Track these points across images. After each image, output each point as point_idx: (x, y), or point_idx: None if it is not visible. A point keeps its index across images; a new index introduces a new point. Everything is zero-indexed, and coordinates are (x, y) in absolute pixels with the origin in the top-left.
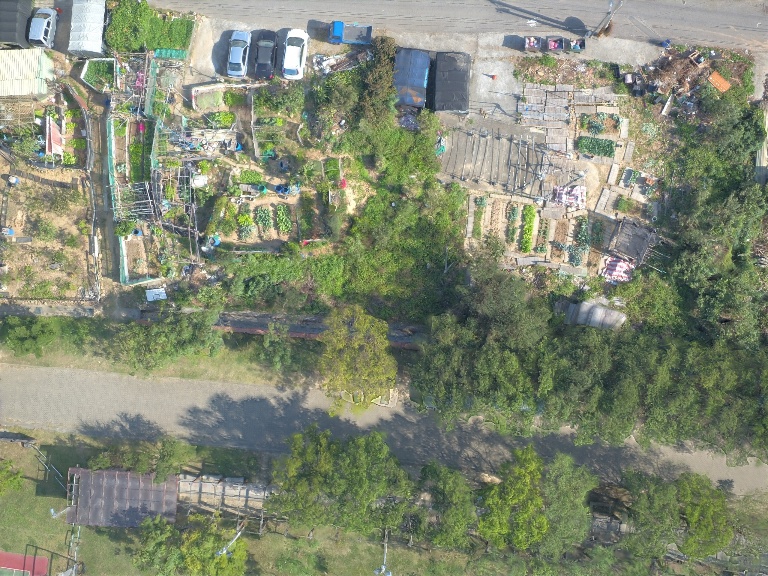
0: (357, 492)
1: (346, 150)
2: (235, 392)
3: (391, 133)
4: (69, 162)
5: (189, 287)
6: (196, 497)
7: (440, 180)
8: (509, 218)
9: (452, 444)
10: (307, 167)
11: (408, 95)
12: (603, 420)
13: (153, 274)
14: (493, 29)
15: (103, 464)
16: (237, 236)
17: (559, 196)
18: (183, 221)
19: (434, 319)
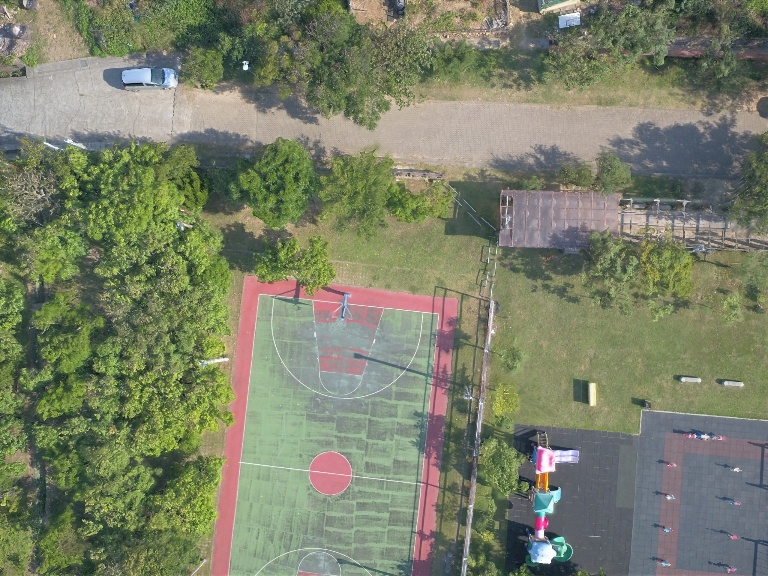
0: None
1: None
2: (657, 118)
3: None
4: None
5: (608, 9)
6: None
7: None
8: None
9: None
10: None
11: None
12: None
13: None
14: None
15: None
16: None
17: None
18: None
19: None
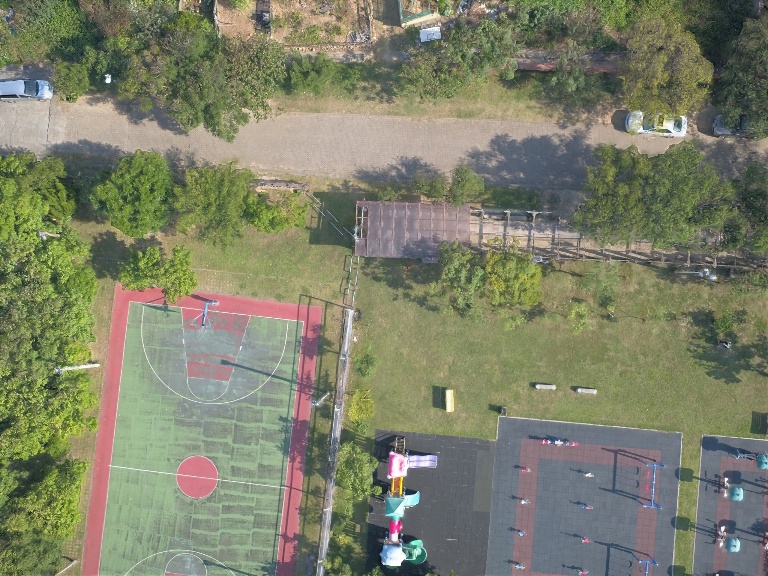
0: (683, 190)
1: None
2: (515, 130)
3: None
4: None
5: (467, 23)
6: (476, 238)
7: None
8: None
9: (742, 174)
10: None
11: None
12: None
13: None
14: None
15: (391, 197)
16: None
17: None
18: None
19: (746, 23)
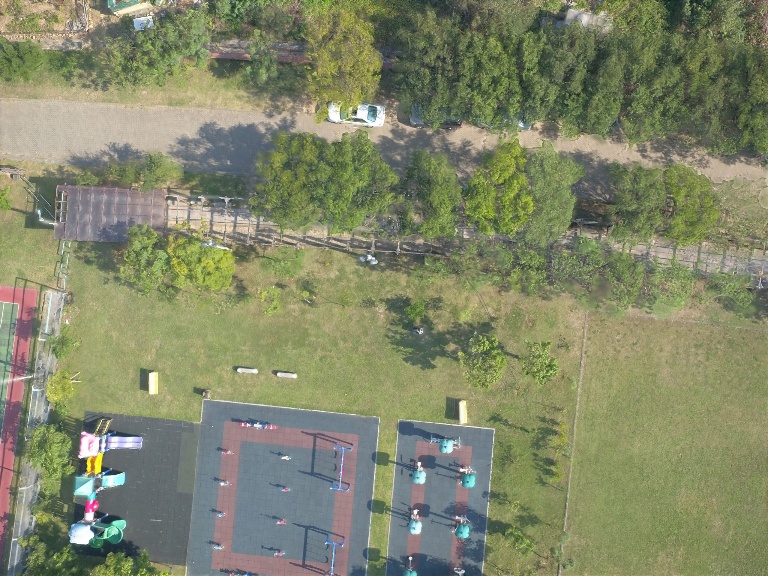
0: (343, 176)
1: None
2: (223, 118)
3: None
4: None
5: (176, 13)
6: None
7: None
8: None
9: None
10: None
11: None
12: (589, 100)
13: (140, 2)
14: None
15: (91, 182)
16: None
17: None
18: None
19: (420, 15)
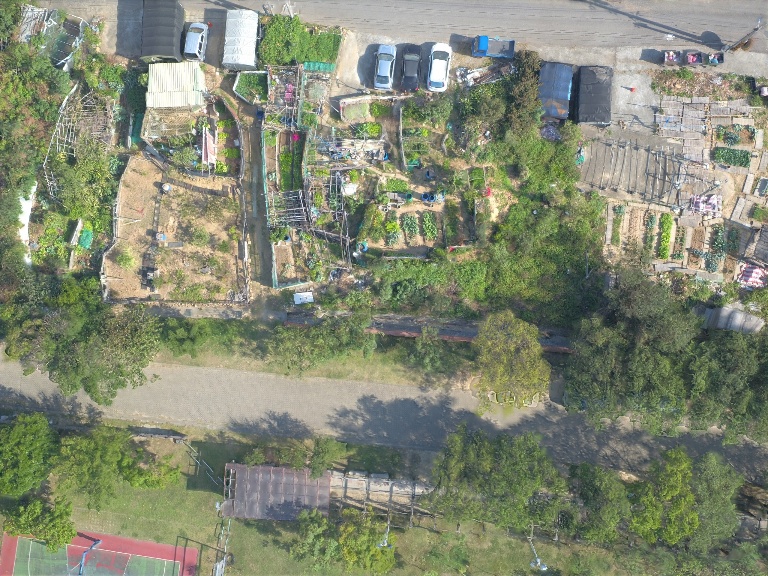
0: (516, 488)
1: (490, 160)
2: (380, 392)
3: (533, 143)
4: (221, 171)
5: (336, 291)
6: (342, 492)
7: (580, 189)
8: (647, 226)
9: (591, 443)
10: (456, 176)
11: (553, 107)
12: (753, 421)
13: (301, 278)
14: (631, 43)
15: (258, 460)
16: (384, 242)
17: (696, 205)
18: (331, 227)
19: (585, 323)
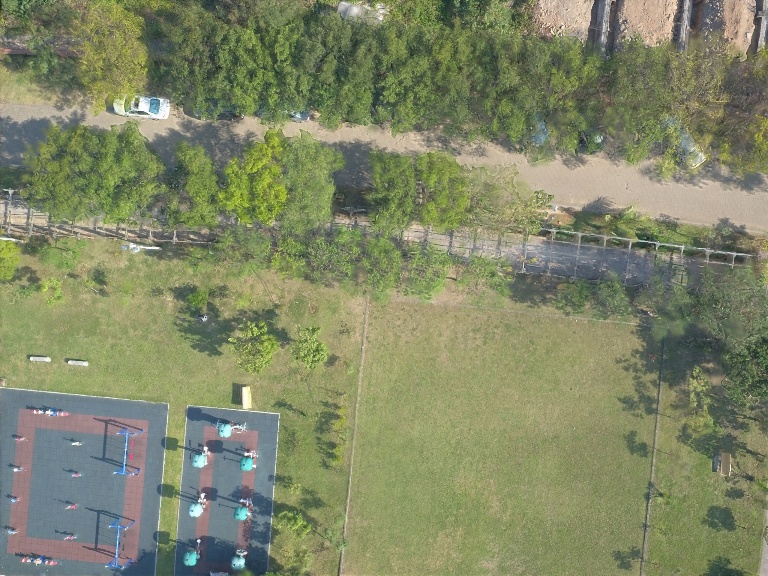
0: (102, 167)
1: None
2: (16, 113)
3: None
4: None
5: None
6: None
7: None
8: None
9: (224, 155)
10: None
11: None
12: (340, 90)
13: None
14: None
15: None
16: None
17: None
18: None
19: (186, 9)
